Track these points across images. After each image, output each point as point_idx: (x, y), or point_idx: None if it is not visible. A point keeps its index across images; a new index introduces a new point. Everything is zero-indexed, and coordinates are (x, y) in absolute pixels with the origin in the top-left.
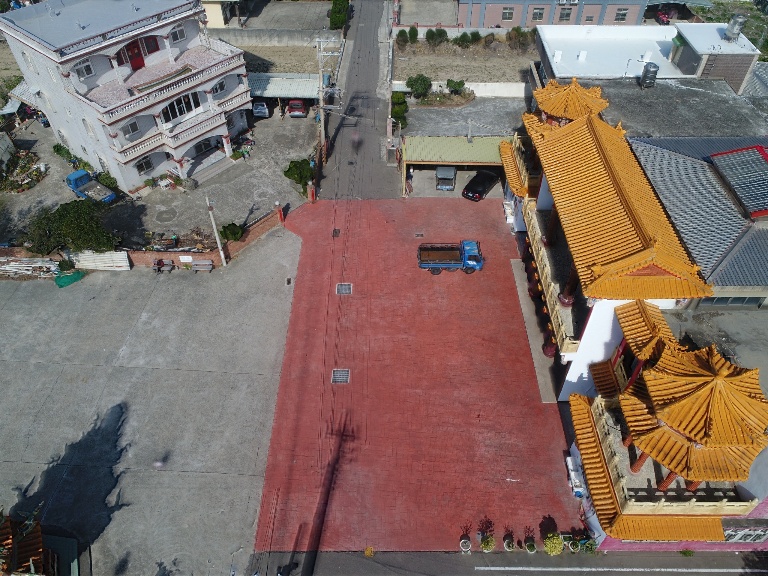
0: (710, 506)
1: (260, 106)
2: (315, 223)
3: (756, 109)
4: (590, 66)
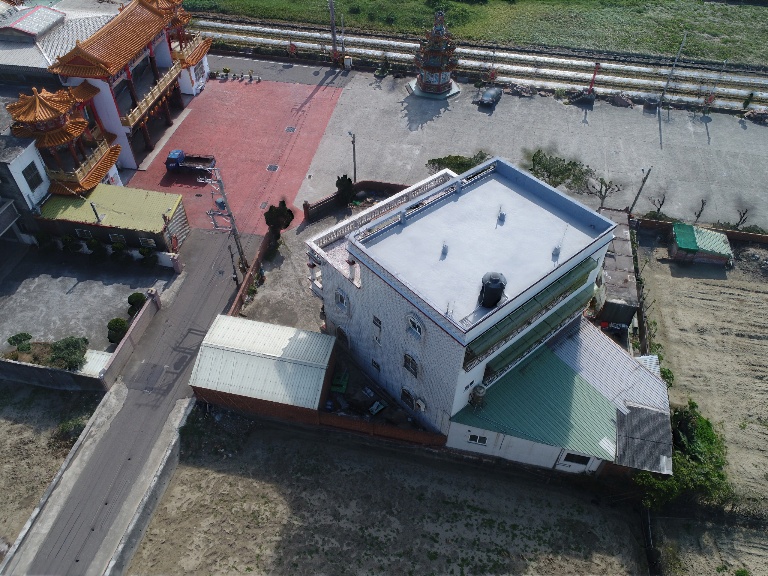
0: None
1: None
2: None
3: None
4: None
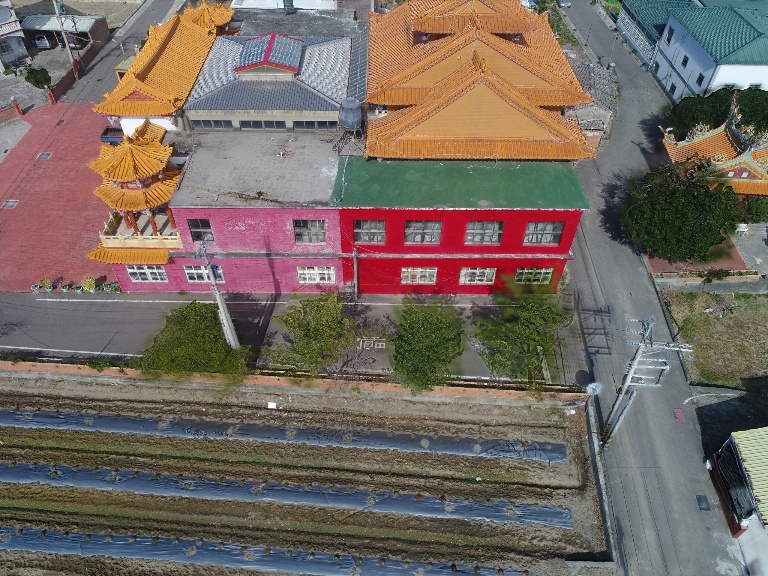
0: (154, 239)
1: (41, 38)
2: (47, 117)
3: (357, 28)
4: (272, 4)
